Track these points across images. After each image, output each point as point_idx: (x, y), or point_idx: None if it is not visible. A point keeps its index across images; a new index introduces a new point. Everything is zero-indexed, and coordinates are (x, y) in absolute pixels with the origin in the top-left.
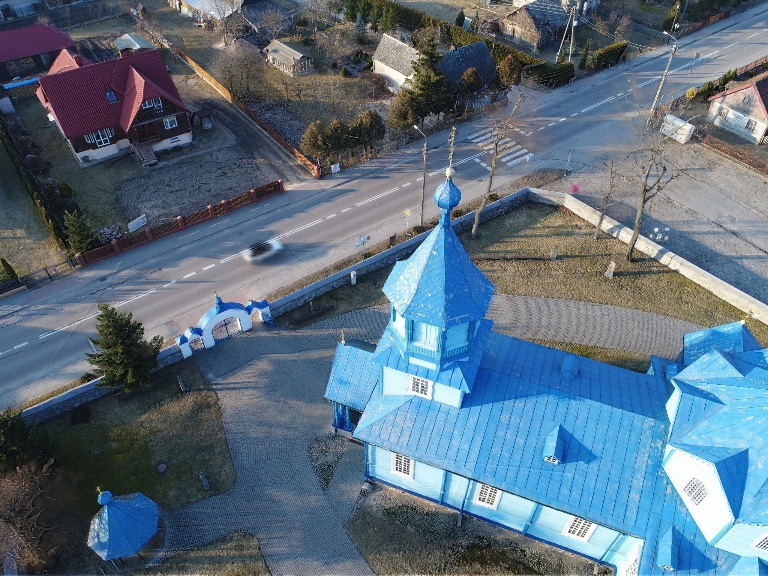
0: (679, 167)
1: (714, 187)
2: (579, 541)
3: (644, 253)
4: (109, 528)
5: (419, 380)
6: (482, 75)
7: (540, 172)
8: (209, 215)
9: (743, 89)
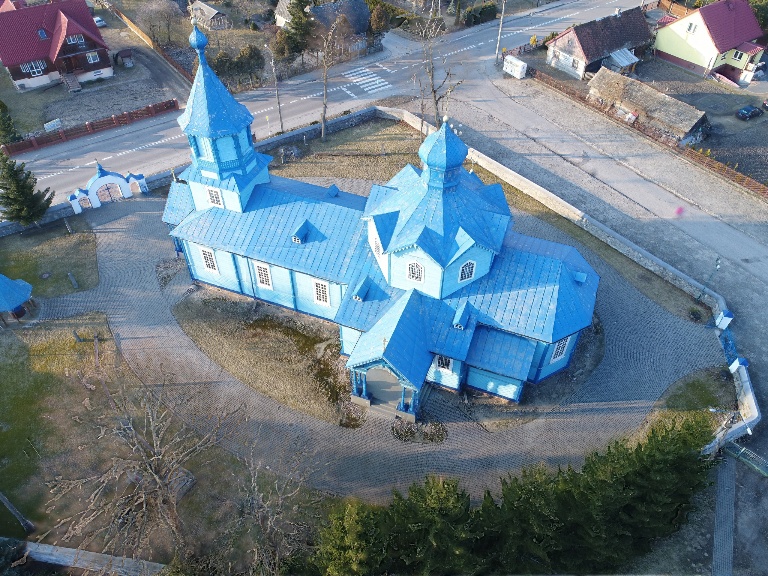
0: (509, 95)
1: (531, 109)
2: (327, 307)
3: None
4: None
5: (212, 191)
6: (359, 24)
7: (392, 97)
8: (114, 123)
9: (566, 33)
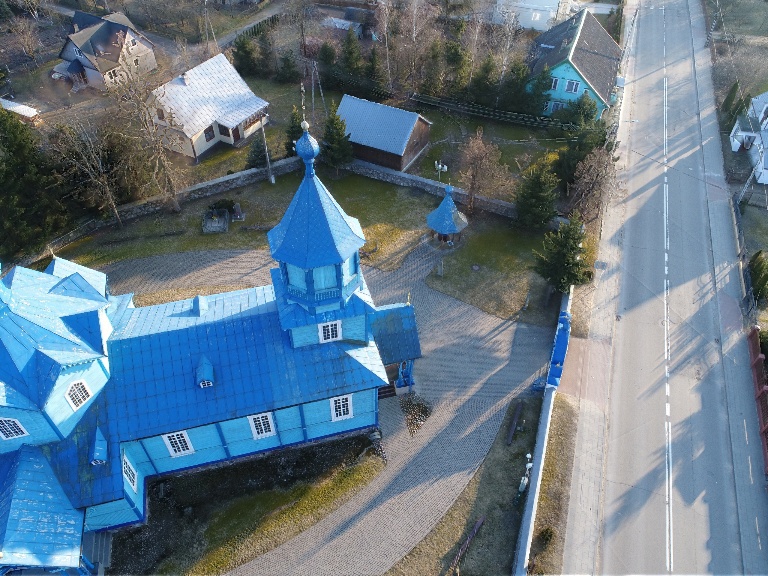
0: None
1: None
2: None
3: None
4: None
5: None
6: None
7: None
8: None
9: None
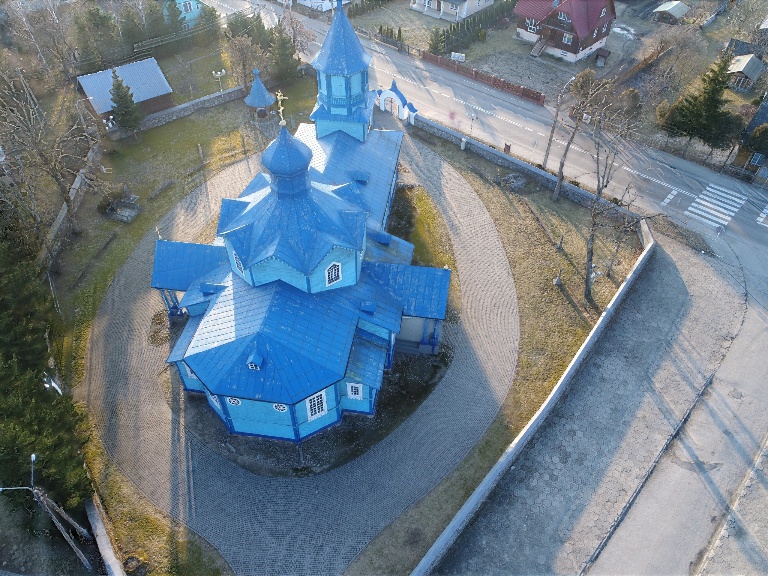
0: None
1: None
2: None
3: None
4: None
5: None
6: None
7: (690, 232)
8: (491, 82)
9: None
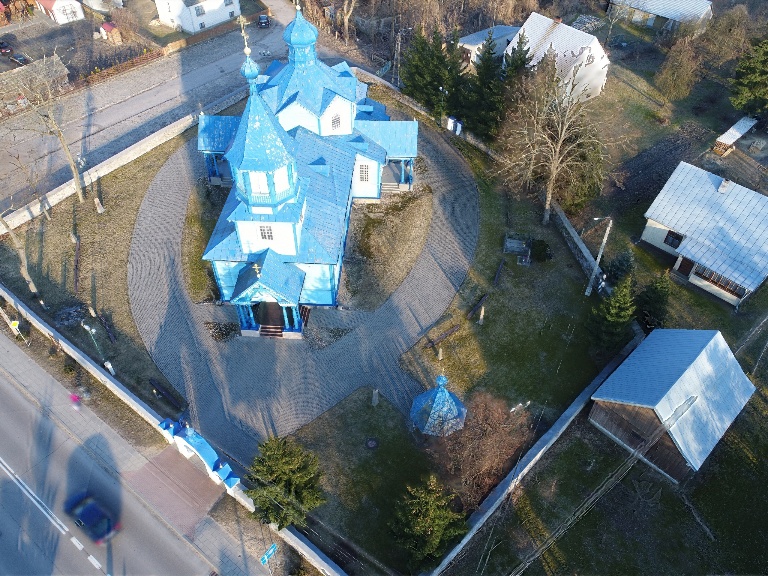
0: None
1: None
2: None
3: (74, 193)
4: (451, 398)
5: None
6: None
7: None
8: None
9: None
